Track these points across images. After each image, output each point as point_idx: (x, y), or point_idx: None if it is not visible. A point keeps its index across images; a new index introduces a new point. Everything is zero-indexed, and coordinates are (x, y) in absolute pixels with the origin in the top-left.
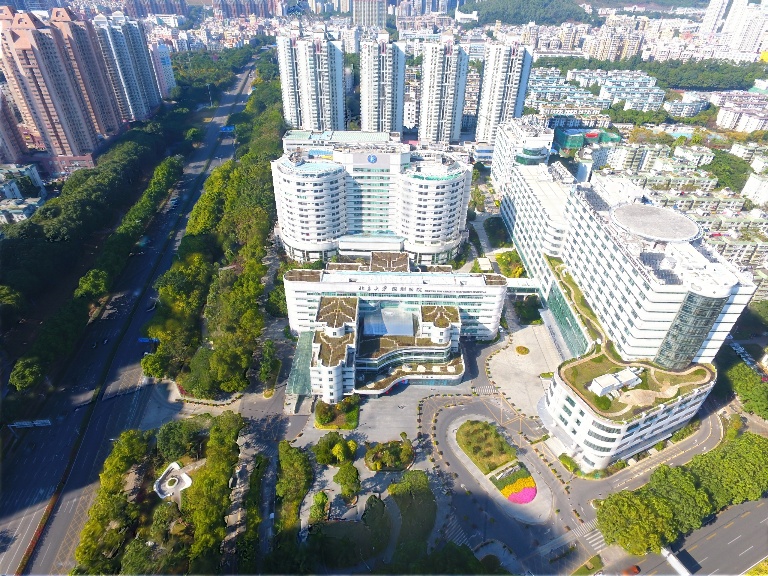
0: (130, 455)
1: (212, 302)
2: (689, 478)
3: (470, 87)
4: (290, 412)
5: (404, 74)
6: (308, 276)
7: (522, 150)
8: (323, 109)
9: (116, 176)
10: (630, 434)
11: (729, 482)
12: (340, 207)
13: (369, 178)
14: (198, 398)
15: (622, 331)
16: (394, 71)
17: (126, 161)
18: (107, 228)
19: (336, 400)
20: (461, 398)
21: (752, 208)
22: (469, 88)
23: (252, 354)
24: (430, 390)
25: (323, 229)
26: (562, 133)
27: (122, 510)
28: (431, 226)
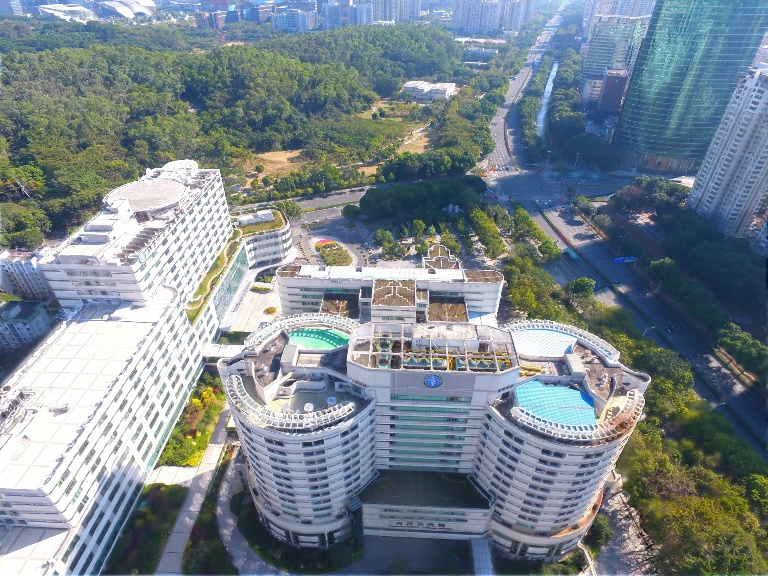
0: (544, 244)
1: None
2: None
3: None
4: None
5: None
6: (478, 277)
7: None
8: None
9: None
10: None
11: None
12: None
13: None
14: None
15: None
16: None
17: None
18: None
19: None
20: None
21: None
22: None
23: None
24: None
25: None
26: None
27: None
28: None
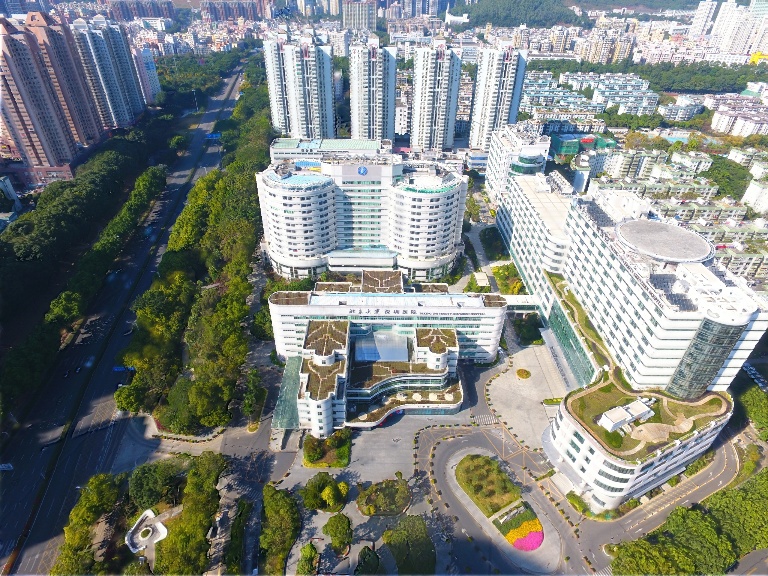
0: (99, 504)
1: (193, 325)
2: (710, 523)
3: (462, 91)
4: (276, 448)
5: (395, 79)
6: (295, 299)
7: (518, 158)
8: (312, 116)
9: (94, 188)
10: (644, 473)
11: (752, 526)
12: (329, 221)
13: (359, 191)
14: (177, 434)
15: (631, 358)
16: (385, 76)
17: (106, 172)
18: (85, 243)
19: (326, 434)
20: (460, 429)
21: (753, 216)
22: (461, 92)
23: (235, 384)
24: (427, 420)
25: (312, 244)
26: (557, 139)
27: (88, 570)
28: (425, 240)
